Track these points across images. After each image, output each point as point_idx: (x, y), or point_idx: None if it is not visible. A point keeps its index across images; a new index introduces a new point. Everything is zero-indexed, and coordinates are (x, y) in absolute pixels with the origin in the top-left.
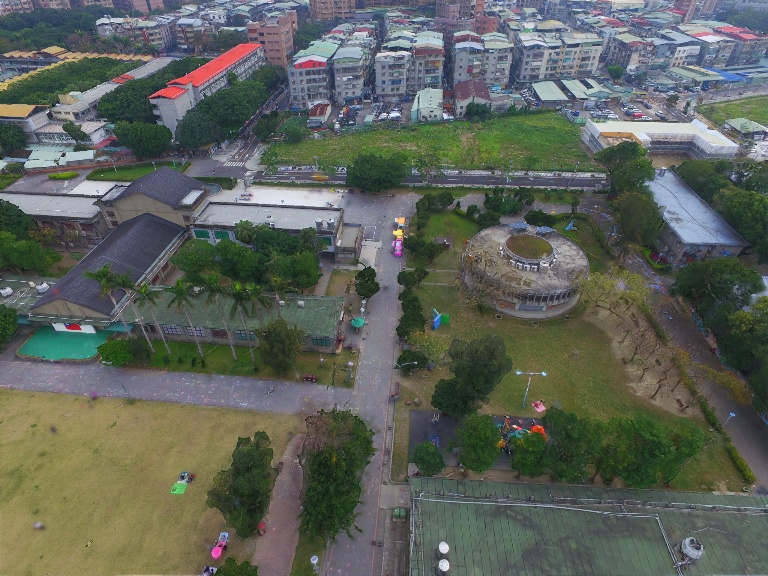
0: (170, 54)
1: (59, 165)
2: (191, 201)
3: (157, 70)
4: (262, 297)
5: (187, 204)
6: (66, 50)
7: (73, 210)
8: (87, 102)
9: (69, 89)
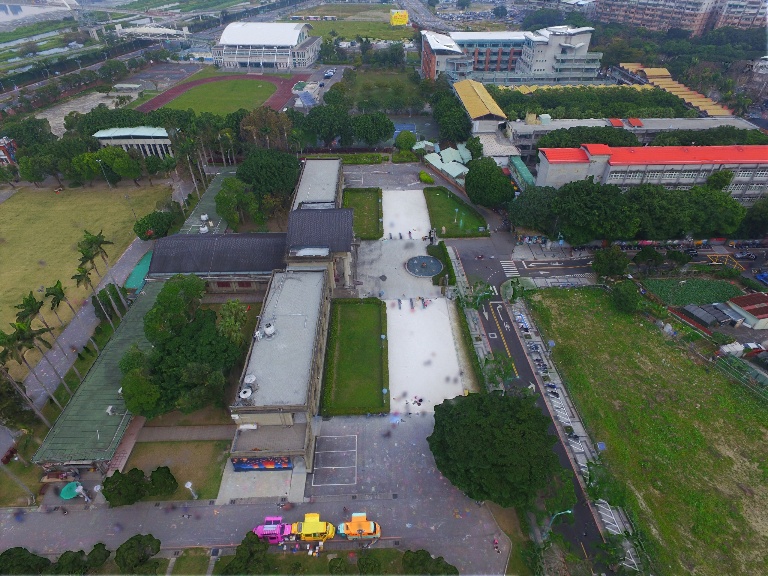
0: (767, 118)
1: (438, 168)
2: (303, 254)
3: (688, 129)
4: (13, 352)
5: (296, 254)
6: (670, 76)
7: (310, 199)
8: (541, 129)
9: (553, 111)
